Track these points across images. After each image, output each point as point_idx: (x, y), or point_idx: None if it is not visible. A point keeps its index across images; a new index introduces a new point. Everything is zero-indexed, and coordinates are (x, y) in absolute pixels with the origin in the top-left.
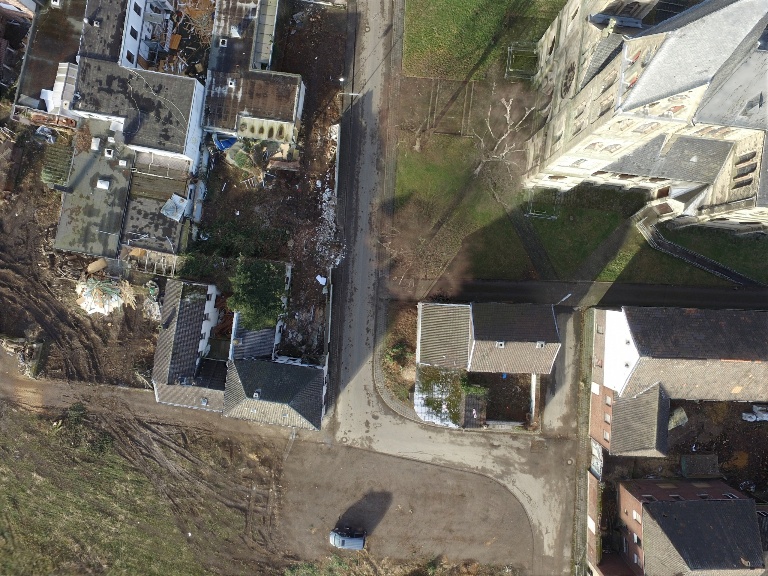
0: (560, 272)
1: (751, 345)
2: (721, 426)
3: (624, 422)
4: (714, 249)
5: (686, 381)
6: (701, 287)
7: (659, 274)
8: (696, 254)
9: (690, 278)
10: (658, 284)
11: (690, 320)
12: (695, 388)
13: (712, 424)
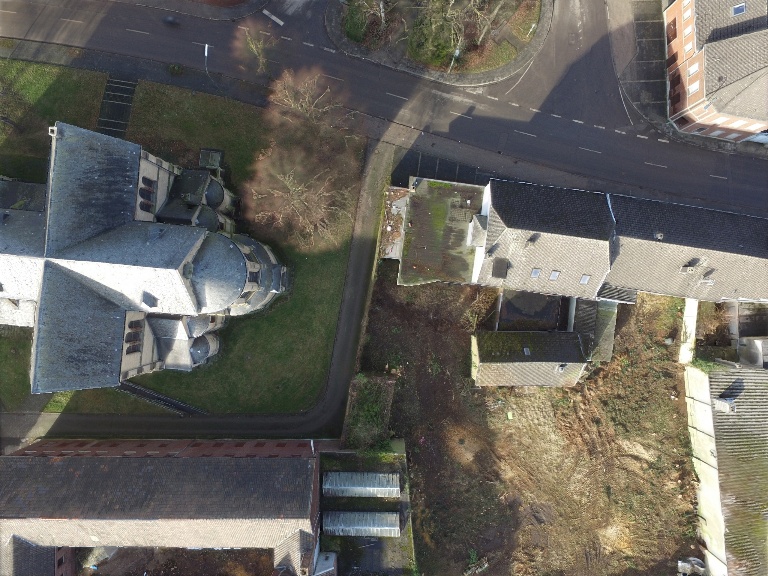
0: (7, 404)
1: (85, 499)
2: (170, 553)
3: (3, 569)
4: (156, 378)
5: (39, 533)
6: (148, 415)
7: (104, 404)
8: (133, 385)
9: (136, 407)
10: (105, 414)
11: (49, 470)
12: (55, 538)
13: (158, 552)
